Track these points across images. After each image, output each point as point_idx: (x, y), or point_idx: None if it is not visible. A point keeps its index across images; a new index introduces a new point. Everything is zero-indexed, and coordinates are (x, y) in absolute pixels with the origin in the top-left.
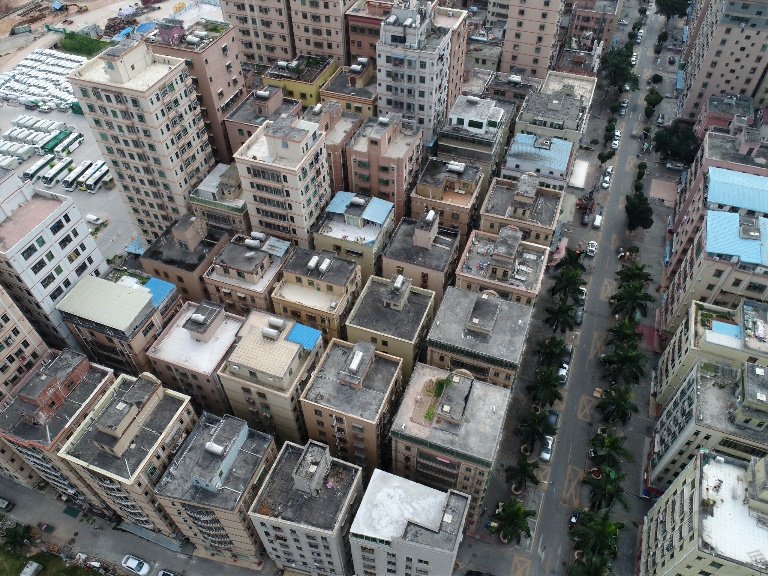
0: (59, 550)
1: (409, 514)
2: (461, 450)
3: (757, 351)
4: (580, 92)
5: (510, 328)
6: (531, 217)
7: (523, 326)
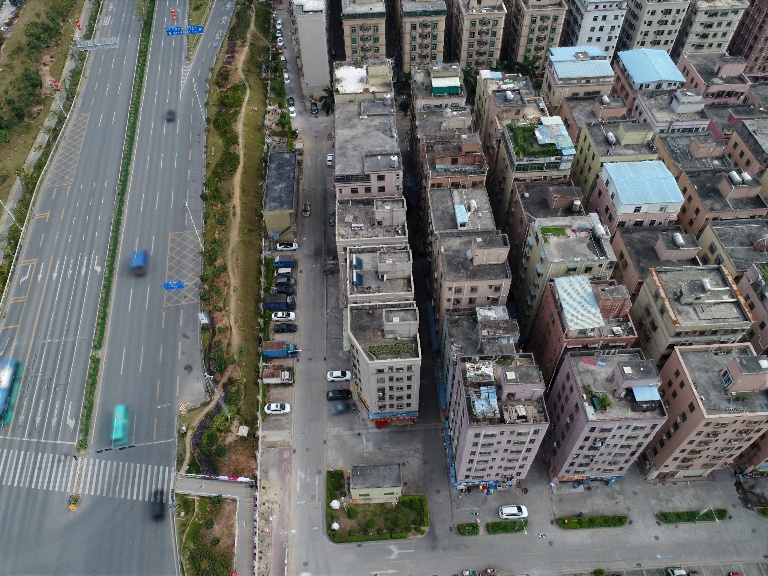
0: (275, 8)
1: (308, 8)
2: (343, 6)
3: (484, 83)
4: (719, 3)
5: (426, 6)
6: (533, 6)
7: (430, 8)
